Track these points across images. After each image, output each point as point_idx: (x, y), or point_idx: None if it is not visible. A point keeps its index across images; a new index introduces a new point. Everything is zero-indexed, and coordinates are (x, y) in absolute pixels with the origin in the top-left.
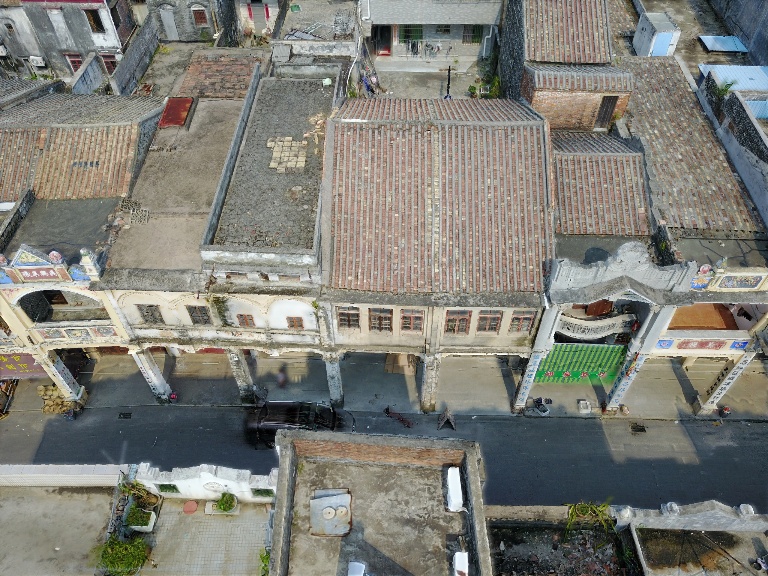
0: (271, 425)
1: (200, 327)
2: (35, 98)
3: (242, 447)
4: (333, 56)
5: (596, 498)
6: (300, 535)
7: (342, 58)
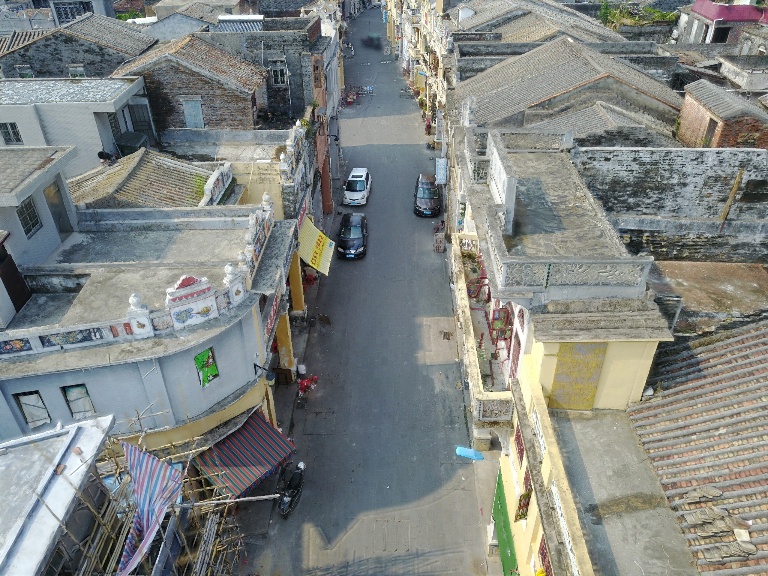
0: None
1: None
2: None
3: None
4: (734, 83)
5: (382, 304)
6: None
7: (736, 86)
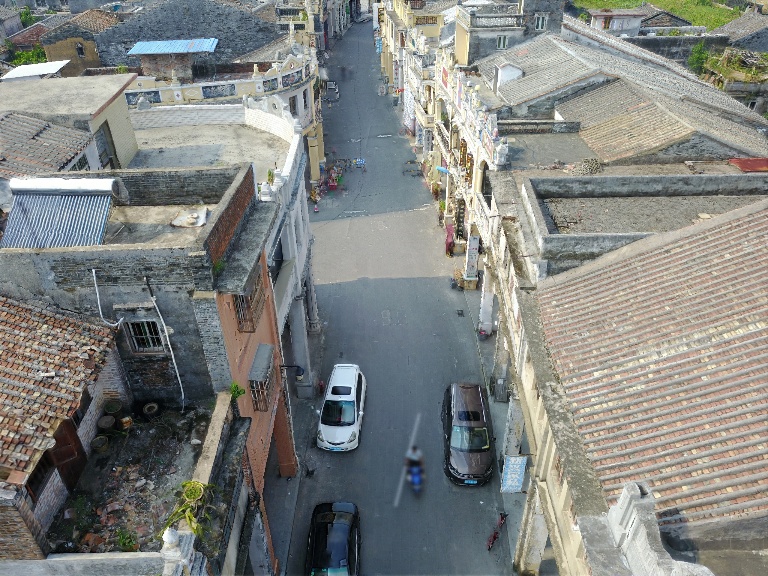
0: (451, 391)
1: (502, 268)
2: (731, 120)
3: (440, 392)
4: None
5: None
6: (182, 208)
7: None
